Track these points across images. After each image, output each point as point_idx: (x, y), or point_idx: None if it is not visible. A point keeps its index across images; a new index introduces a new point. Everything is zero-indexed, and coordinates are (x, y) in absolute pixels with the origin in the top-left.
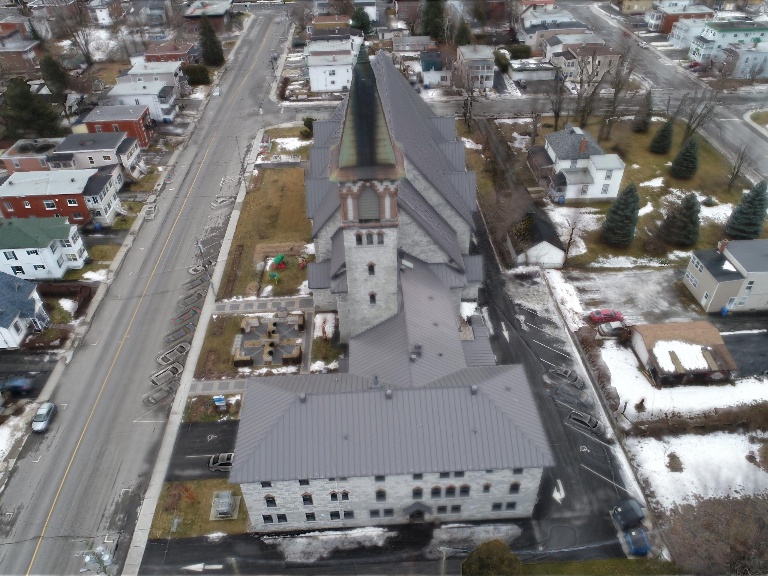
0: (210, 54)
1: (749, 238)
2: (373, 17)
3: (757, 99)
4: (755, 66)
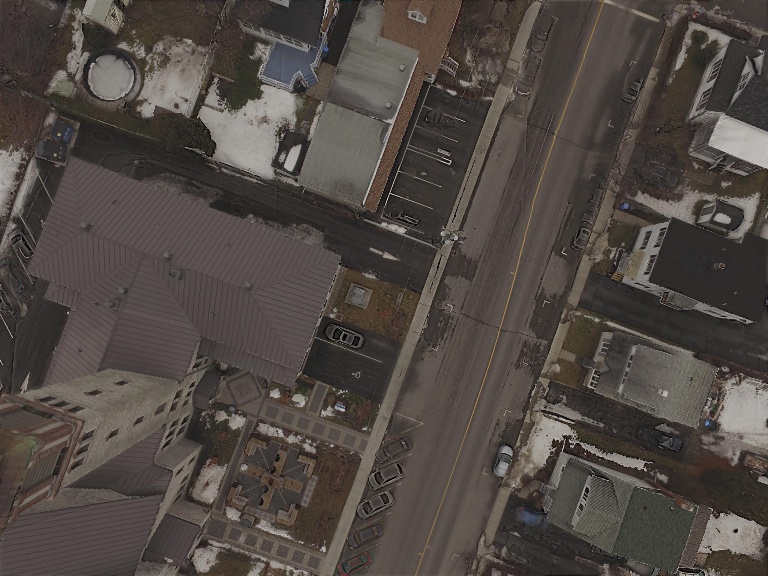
0: None
1: None
2: None
3: None
4: None
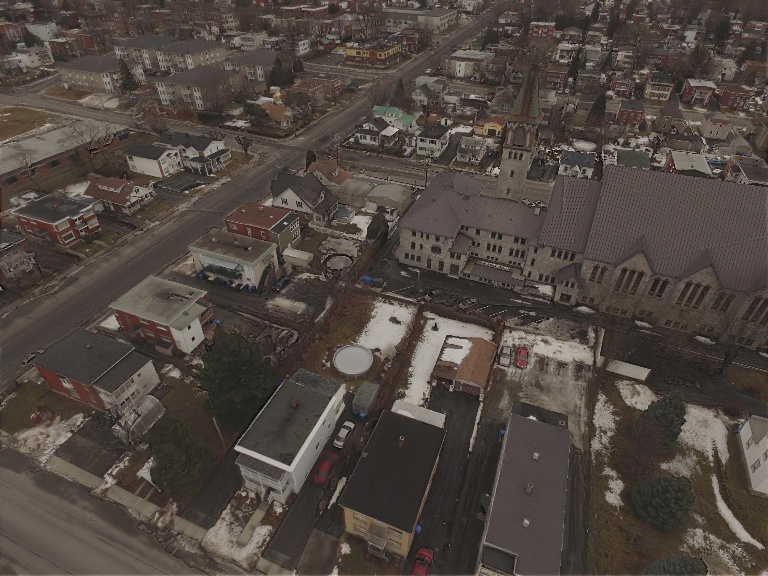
0: None
1: None
2: None
3: None
4: None
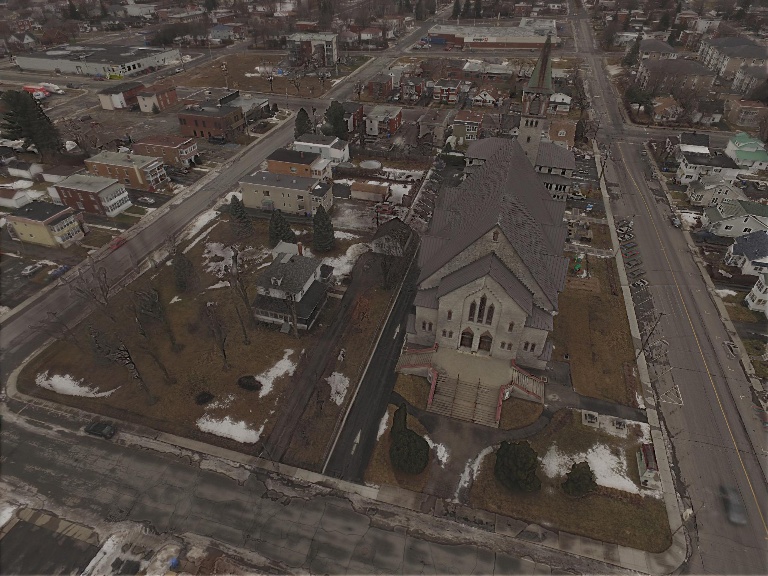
0: None
1: None
2: None
3: None
4: None
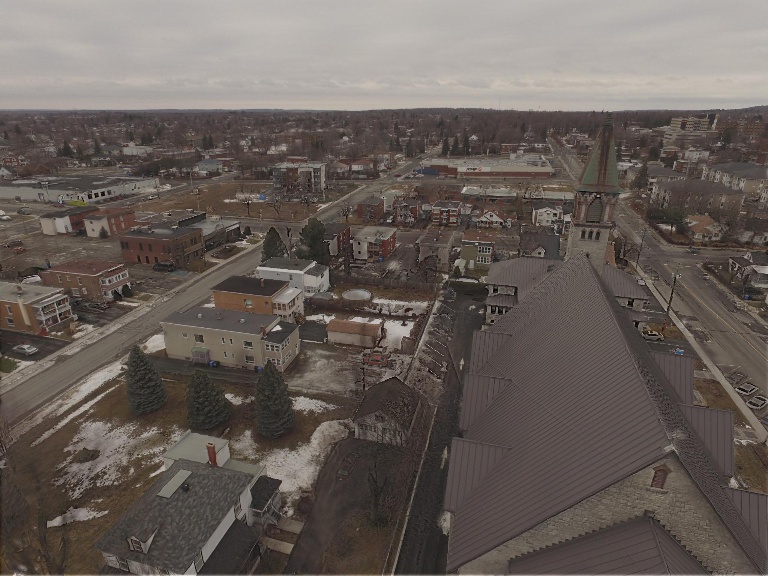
0: None
1: None
2: None
3: None
4: None
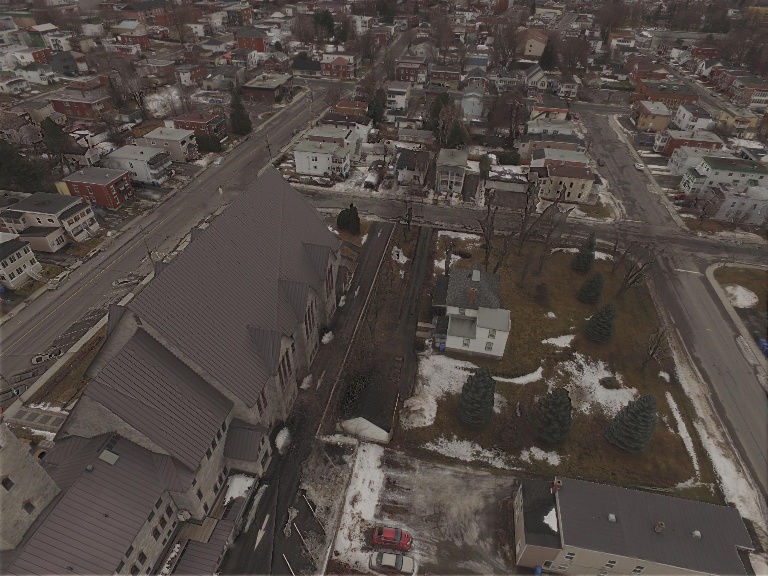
0: (236, 124)
1: (629, 452)
2: (402, 105)
3: (732, 250)
4: (739, 213)
